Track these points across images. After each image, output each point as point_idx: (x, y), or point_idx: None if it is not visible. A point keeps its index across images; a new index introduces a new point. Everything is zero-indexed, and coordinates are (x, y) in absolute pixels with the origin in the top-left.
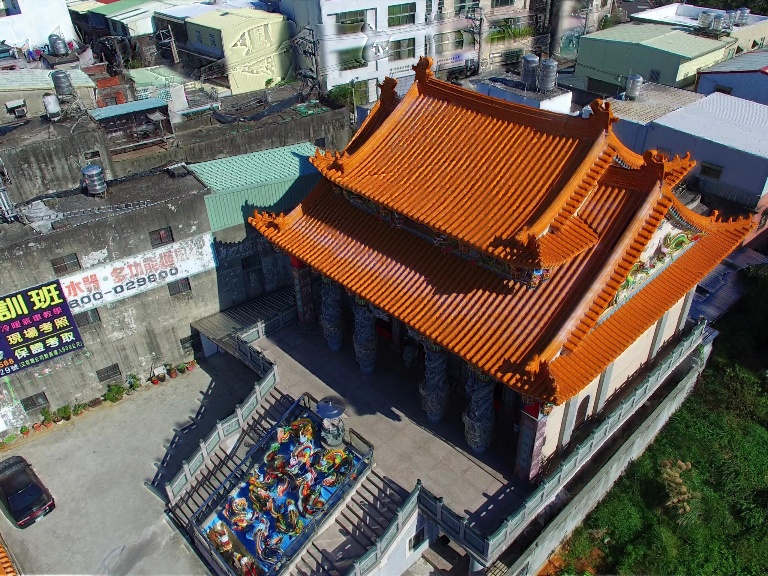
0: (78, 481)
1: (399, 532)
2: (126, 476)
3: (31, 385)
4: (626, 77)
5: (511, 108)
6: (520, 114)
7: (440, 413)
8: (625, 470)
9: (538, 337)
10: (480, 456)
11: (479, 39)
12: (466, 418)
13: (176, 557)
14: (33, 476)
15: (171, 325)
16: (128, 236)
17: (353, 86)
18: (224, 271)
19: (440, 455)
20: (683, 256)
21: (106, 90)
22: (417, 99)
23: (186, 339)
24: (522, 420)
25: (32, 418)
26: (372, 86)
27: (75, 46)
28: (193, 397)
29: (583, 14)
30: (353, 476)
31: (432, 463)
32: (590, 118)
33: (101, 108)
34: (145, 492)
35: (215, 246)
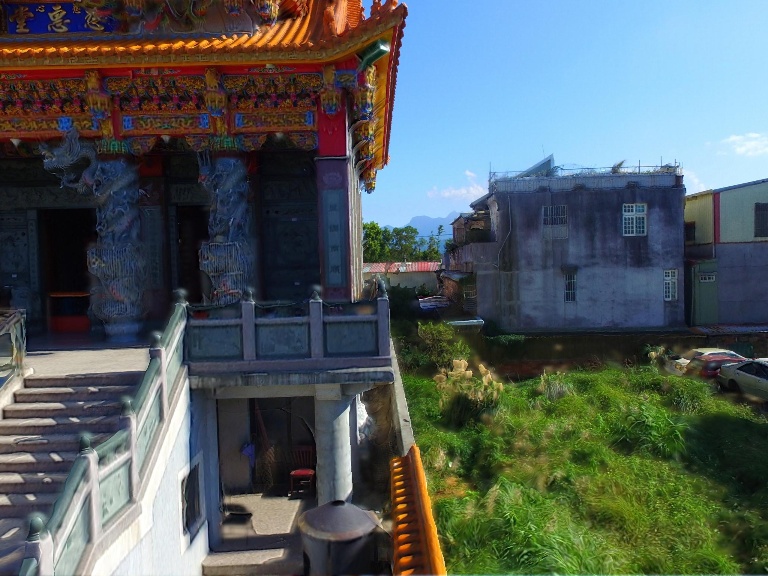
0: None
1: (164, 426)
2: None
3: None
4: None
5: None
6: None
7: (138, 314)
8: None
9: None
10: None
11: None
12: (209, 251)
13: None
14: None
15: None
16: None
17: None
18: None
19: None
20: None
21: None
22: None
23: None
24: (319, 179)
25: None
26: None
27: None
28: None
29: None
30: None
31: None
32: None
33: None
34: None
35: None
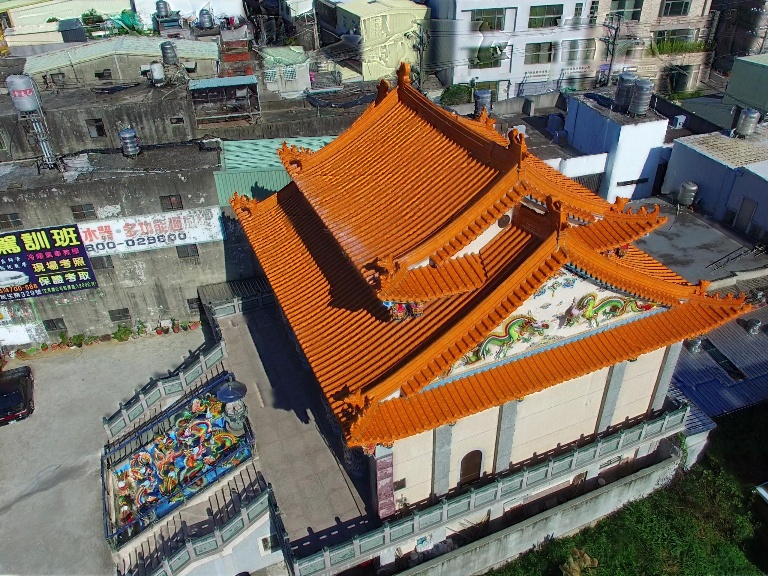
0: (59, 400)
1: (246, 528)
2: (94, 407)
3: (52, 310)
4: (765, 111)
5: (456, 127)
6: (462, 135)
7: None
8: (541, 545)
9: (384, 372)
10: (357, 480)
11: (612, 50)
12: None
13: (91, 488)
14: (23, 386)
15: (179, 284)
16: (140, 197)
17: (473, 85)
18: (232, 245)
19: (321, 467)
20: (629, 324)
21: (237, 64)
22: (395, 105)
23: (194, 300)
24: None
25: (52, 338)
26: (503, 88)
27: (236, 21)
28: (181, 353)
29: (762, 32)
30: (236, 462)
31: (309, 472)
32: (508, 149)
33: (202, 79)
34: (100, 425)
35: (223, 220)
